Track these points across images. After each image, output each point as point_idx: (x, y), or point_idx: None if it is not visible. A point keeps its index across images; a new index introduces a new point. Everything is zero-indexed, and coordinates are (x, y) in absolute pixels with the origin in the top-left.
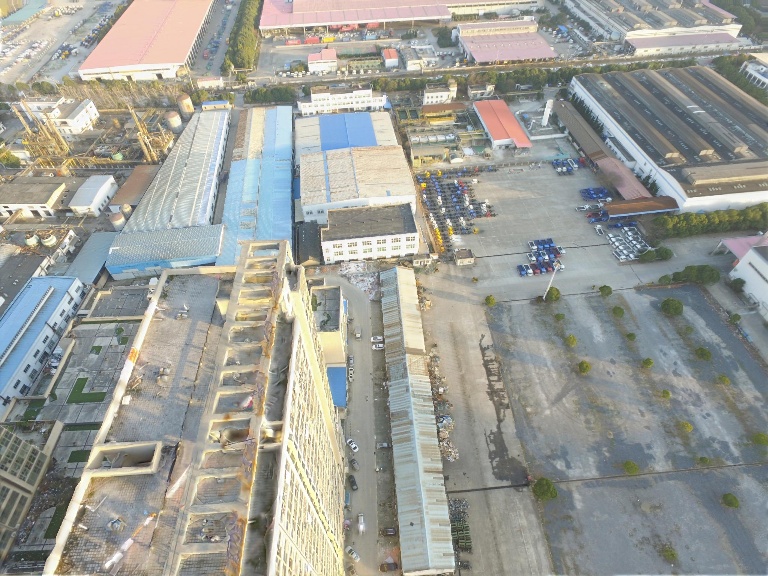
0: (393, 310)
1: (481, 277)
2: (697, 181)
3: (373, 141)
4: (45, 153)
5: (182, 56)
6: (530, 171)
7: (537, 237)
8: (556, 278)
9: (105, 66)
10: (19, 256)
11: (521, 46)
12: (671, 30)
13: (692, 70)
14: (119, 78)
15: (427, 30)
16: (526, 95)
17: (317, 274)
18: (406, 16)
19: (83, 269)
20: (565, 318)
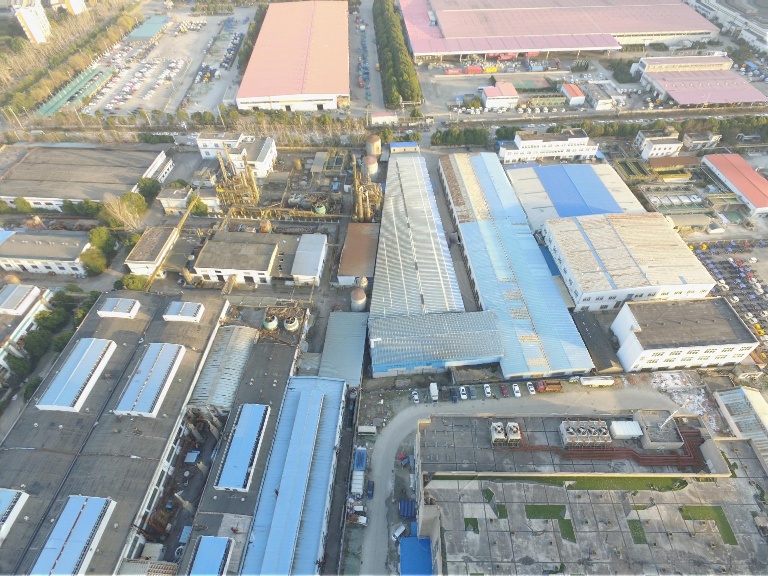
0: None
1: None
2: None
3: (613, 203)
4: (238, 202)
5: (345, 86)
6: None
7: None
8: None
9: (266, 95)
10: (264, 344)
11: (722, 86)
12: None
13: None
14: (278, 108)
15: (594, 61)
16: (756, 148)
17: (627, 386)
18: (573, 46)
19: (340, 364)
20: None
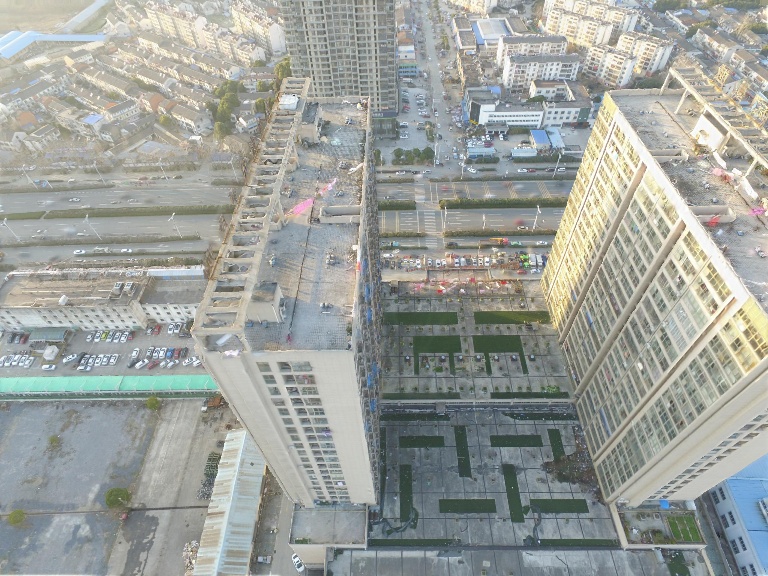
0: None
1: None
2: None
3: None
4: None
5: None
6: None
7: None
8: None
9: None
10: None
11: None
12: None
13: None
14: None
15: None
16: None
17: None
18: None
19: None
20: None
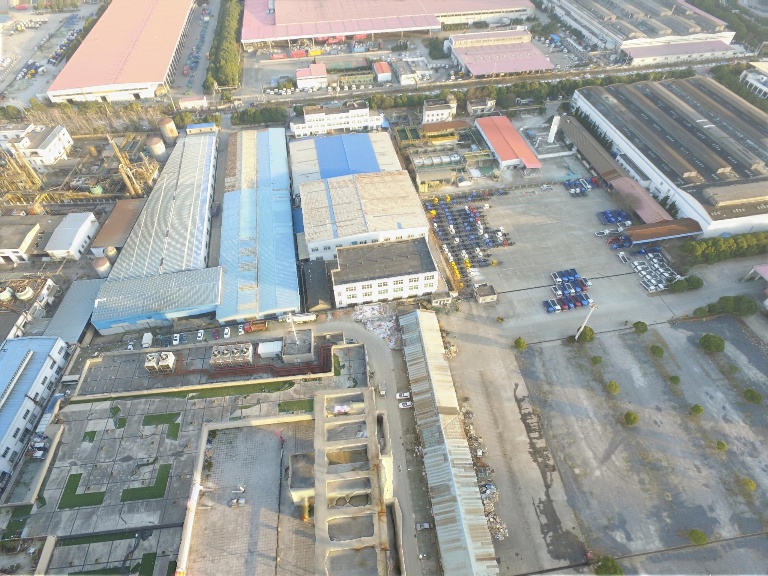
0: (419, 362)
1: (506, 316)
2: (720, 203)
3: (375, 165)
4: (14, 188)
5: (161, 74)
6: (542, 193)
7: (559, 267)
8: (585, 314)
9: (77, 87)
10: None
11: (517, 57)
12: (666, 39)
13: (694, 81)
14: (92, 99)
15: (417, 41)
16: (528, 110)
17: (329, 320)
18: (395, 27)
19: (65, 325)
20: (601, 360)
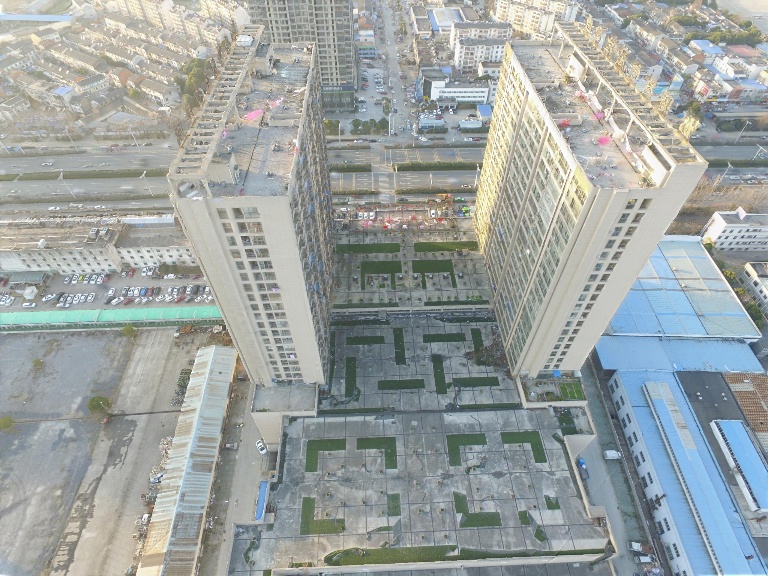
0: None
1: None
2: None
3: None
4: None
5: None
6: None
7: None
8: None
9: None
10: None
11: None
12: None
13: None
14: None
15: None
16: None
17: None
18: None
19: None
20: None
